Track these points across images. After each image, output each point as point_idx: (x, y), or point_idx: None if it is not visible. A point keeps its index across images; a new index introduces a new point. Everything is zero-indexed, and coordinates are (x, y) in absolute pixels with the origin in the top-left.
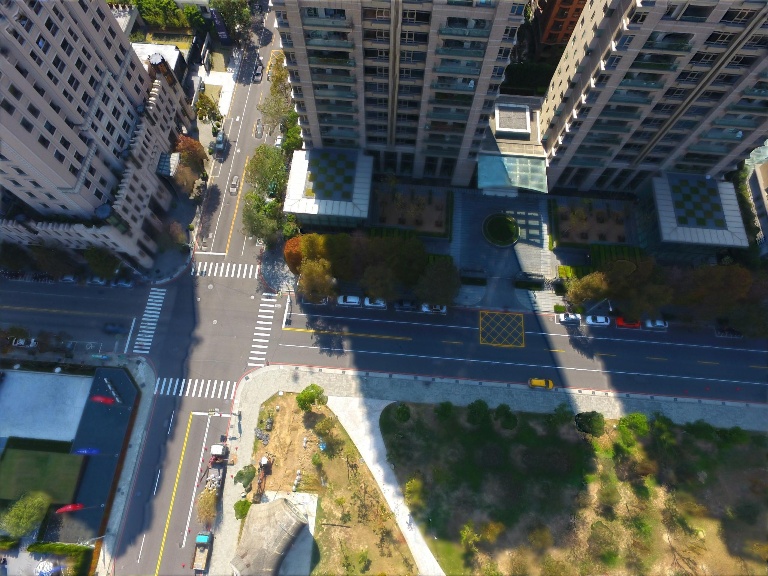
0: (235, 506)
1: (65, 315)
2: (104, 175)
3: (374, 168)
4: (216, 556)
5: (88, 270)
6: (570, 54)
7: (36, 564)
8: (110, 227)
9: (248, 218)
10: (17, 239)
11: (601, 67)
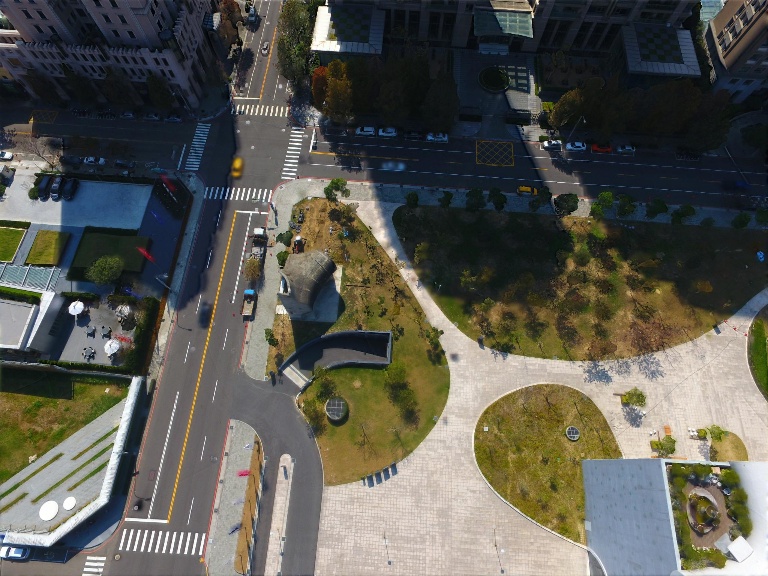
0: (278, 255)
1: (126, 142)
2: (164, 11)
3: (385, 33)
4: (260, 308)
5: (144, 110)
6: None
7: (114, 313)
8: (170, 50)
9: (282, 51)
10: (89, 71)
11: None
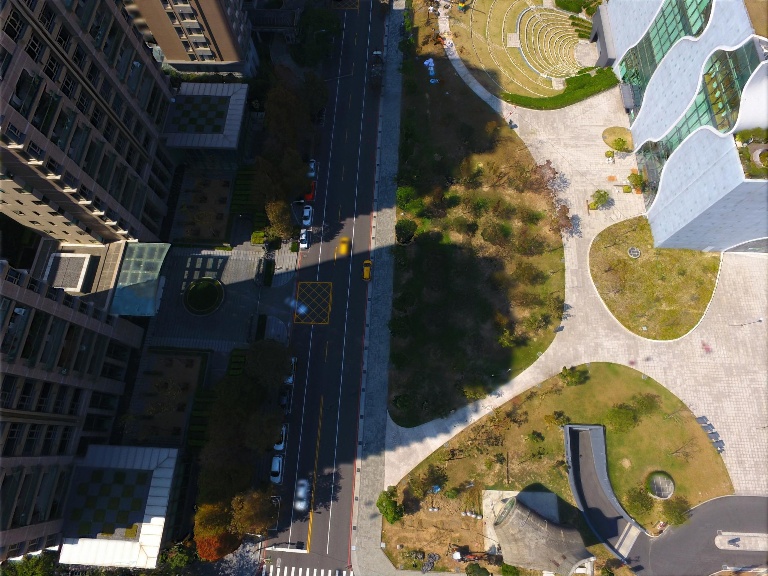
0: None
1: None
2: None
3: None
4: None
5: None
6: (1, 197)
7: None
8: None
9: None
10: None
11: (38, 165)
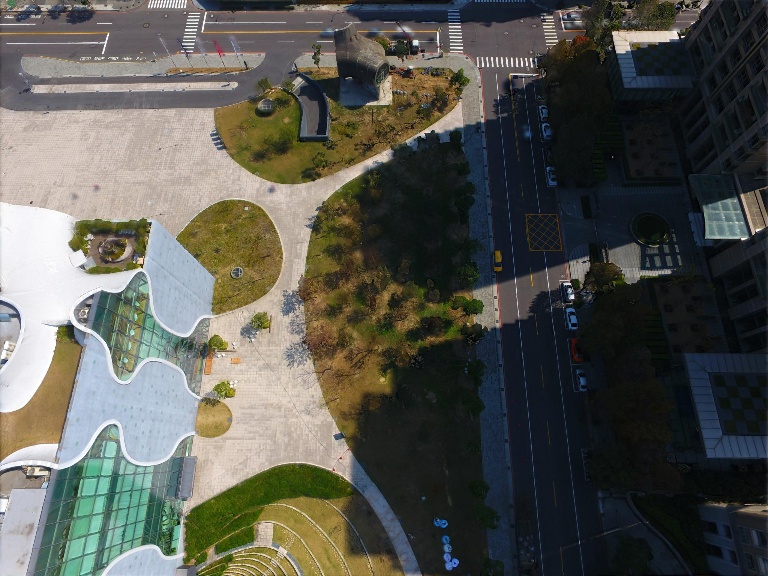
0: None
1: None
2: None
3: None
4: None
5: None
6: None
7: None
8: None
9: (598, 6)
10: None
11: None
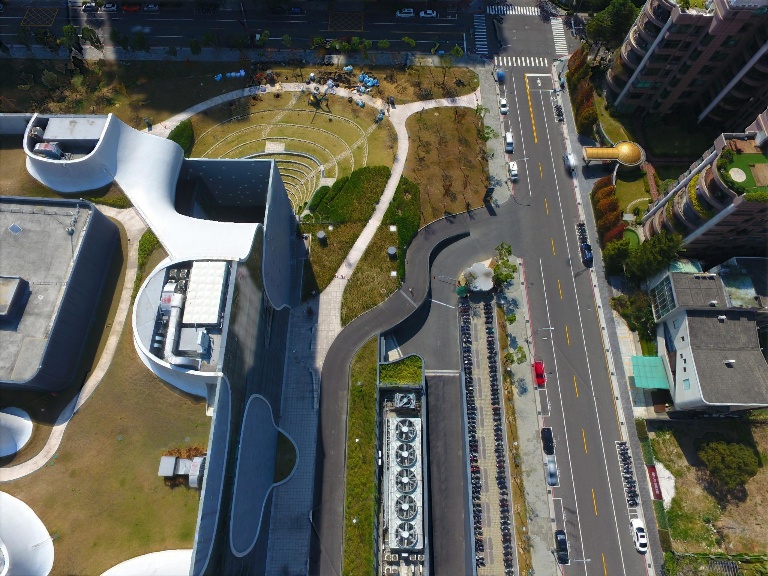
0: None
1: None
2: None
3: None
4: None
5: None
6: None
7: None
8: None
9: None
10: None
11: None
